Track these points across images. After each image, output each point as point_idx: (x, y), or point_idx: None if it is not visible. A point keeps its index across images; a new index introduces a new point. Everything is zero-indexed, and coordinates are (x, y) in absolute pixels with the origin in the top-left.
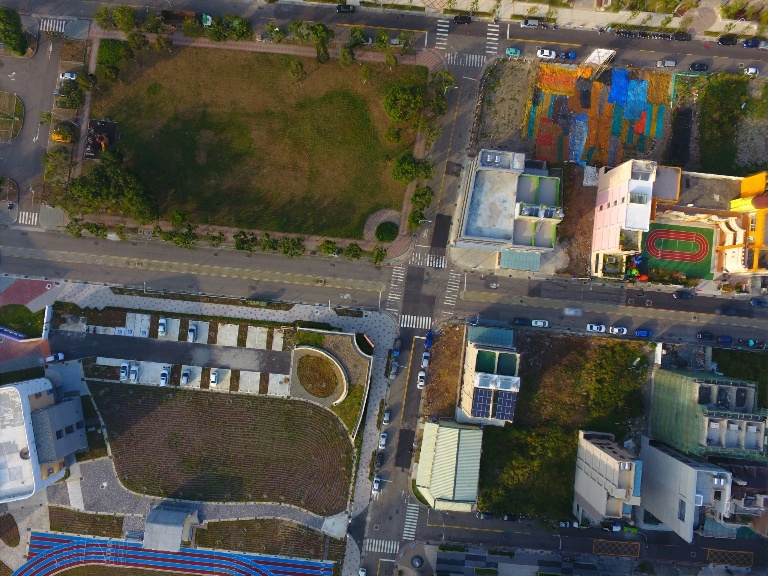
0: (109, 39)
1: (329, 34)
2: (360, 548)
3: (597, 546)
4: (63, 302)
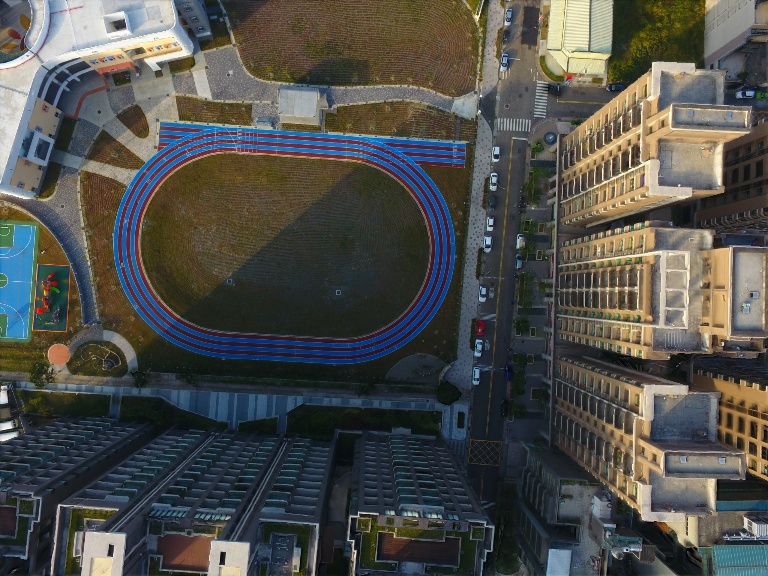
0: None
1: None
2: (492, 128)
3: None
4: None
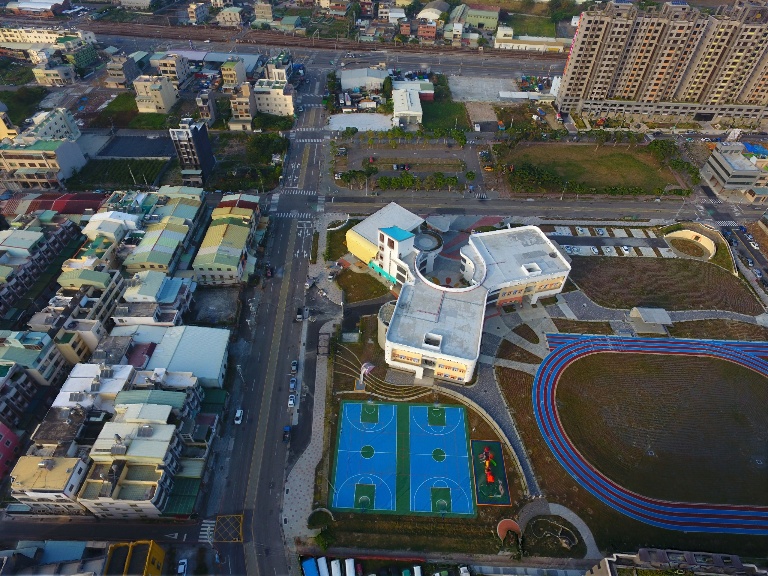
0: None
1: None
2: None
3: None
4: None
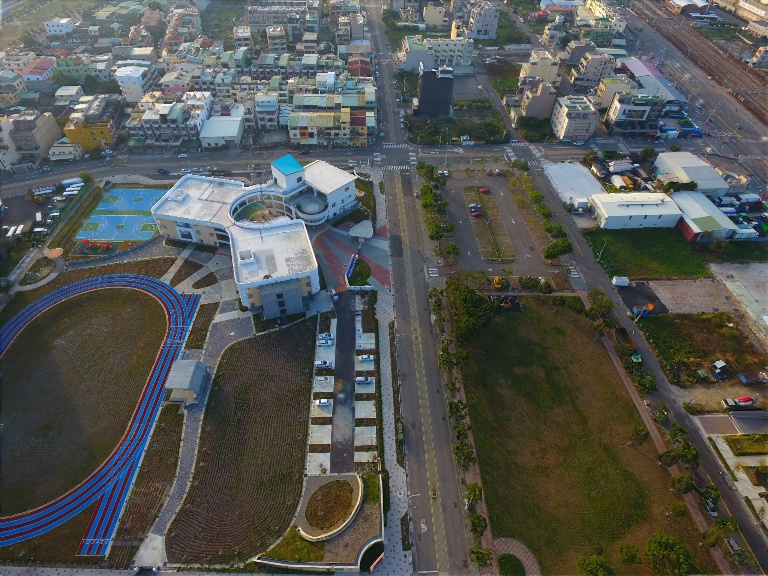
0: (582, 301)
1: (693, 462)
2: None
3: None
4: (377, 295)
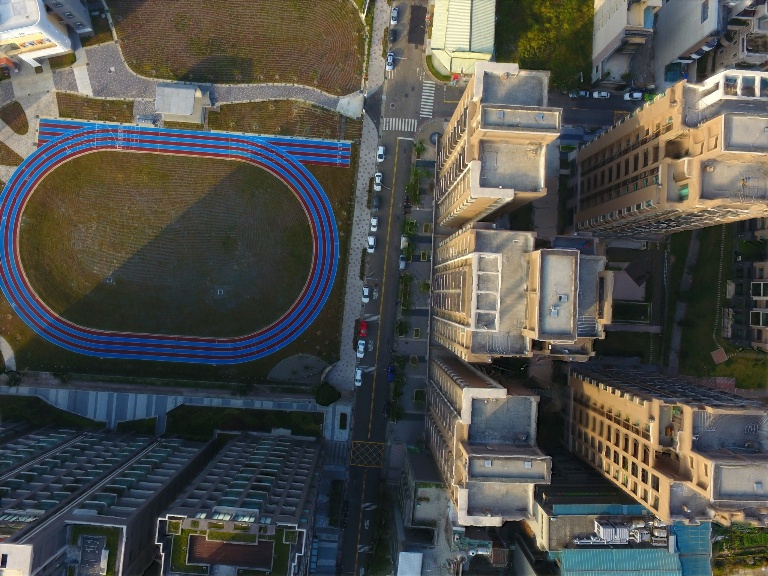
0: None
1: None
2: (377, 127)
3: (618, 118)
4: None
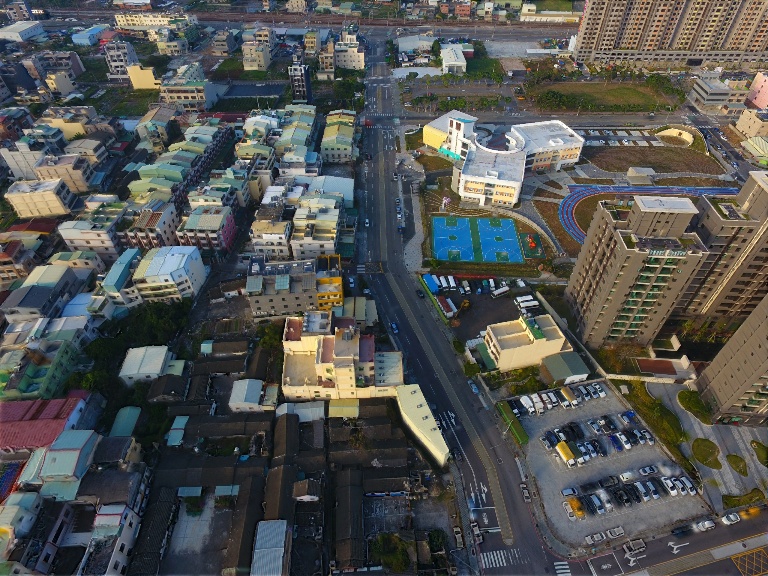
0: None
1: None
2: None
3: None
4: None
